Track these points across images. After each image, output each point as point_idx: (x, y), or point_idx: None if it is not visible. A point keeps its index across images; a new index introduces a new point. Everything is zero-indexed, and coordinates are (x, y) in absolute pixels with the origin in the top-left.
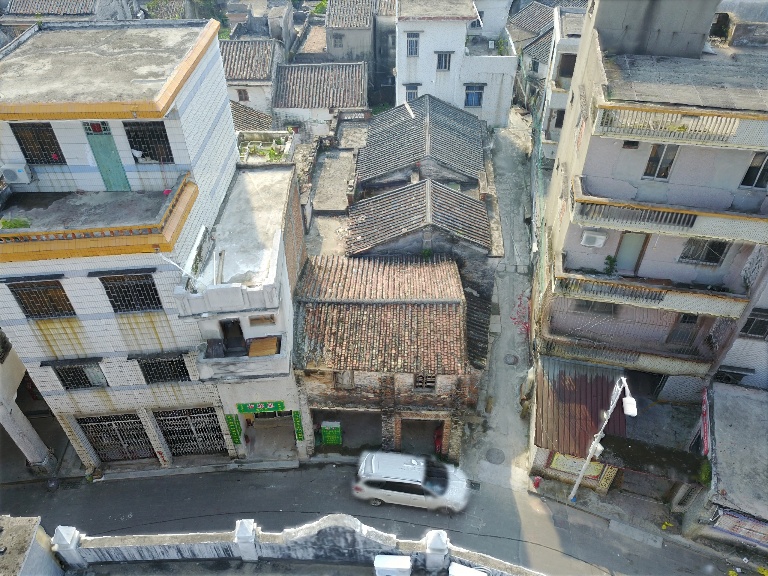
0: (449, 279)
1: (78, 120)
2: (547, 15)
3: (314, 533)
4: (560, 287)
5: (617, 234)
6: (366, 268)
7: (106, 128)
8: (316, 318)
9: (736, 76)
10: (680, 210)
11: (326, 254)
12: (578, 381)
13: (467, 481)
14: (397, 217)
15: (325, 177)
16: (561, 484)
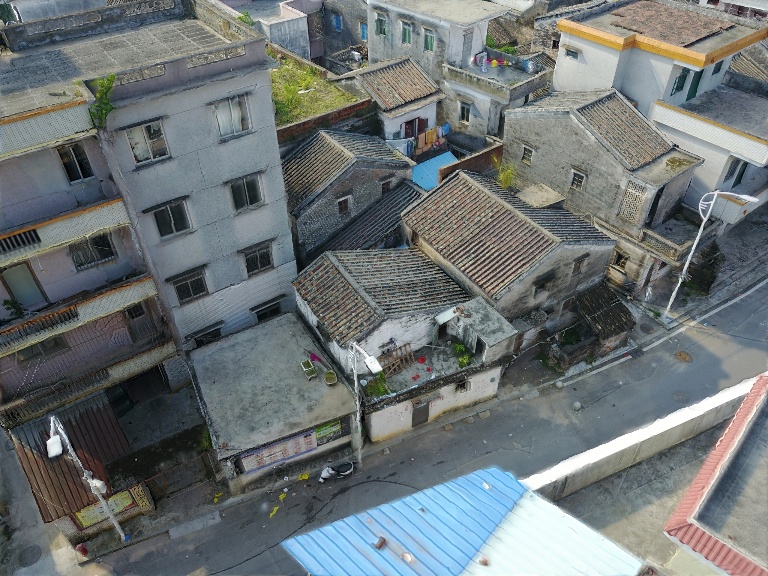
0: None
1: None
2: None
3: None
4: None
5: None
6: None
7: None
8: None
9: (9, 82)
10: (13, 232)
11: None
12: None
13: None
14: None
15: None
16: (109, 533)
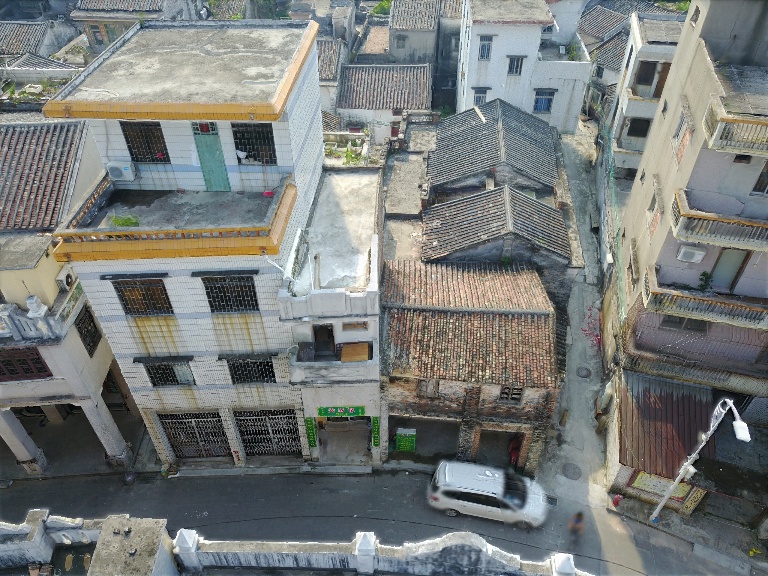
0: (533, 289)
1: (188, 120)
2: (612, 20)
3: (438, 550)
4: (653, 302)
5: (716, 250)
6: (445, 274)
7: (214, 128)
8: (401, 324)
9: None
10: None
11: (401, 258)
12: (664, 399)
13: (543, 495)
14: (475, 223)
15: (396, 180)
16: (641, 503)
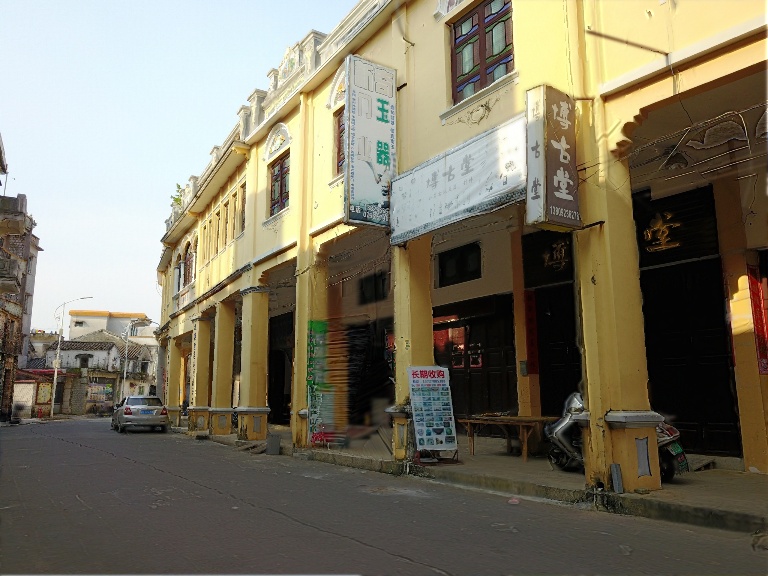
0: None
1: None
2: None
3: None
4: None
5: None
6: None
7: None
8: None
9: None
10: (8, 251)
11: None
12: None
13: None
14: None
15: None
16: (41, 417)
